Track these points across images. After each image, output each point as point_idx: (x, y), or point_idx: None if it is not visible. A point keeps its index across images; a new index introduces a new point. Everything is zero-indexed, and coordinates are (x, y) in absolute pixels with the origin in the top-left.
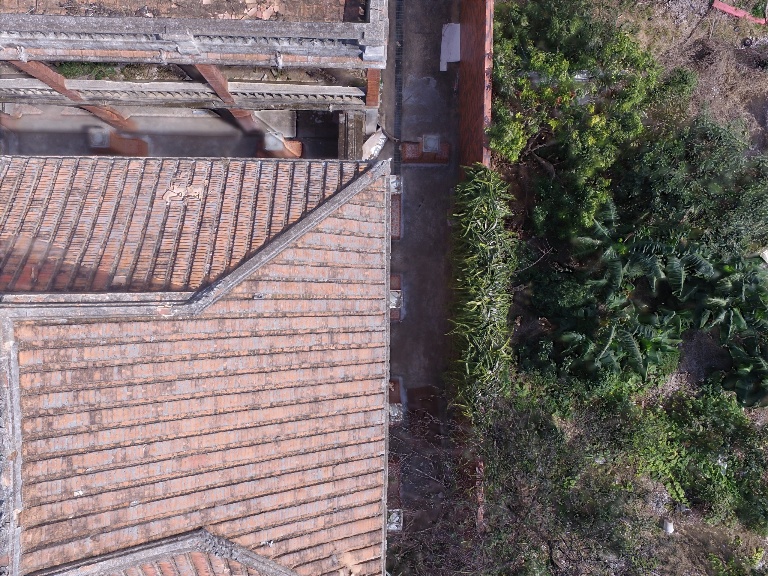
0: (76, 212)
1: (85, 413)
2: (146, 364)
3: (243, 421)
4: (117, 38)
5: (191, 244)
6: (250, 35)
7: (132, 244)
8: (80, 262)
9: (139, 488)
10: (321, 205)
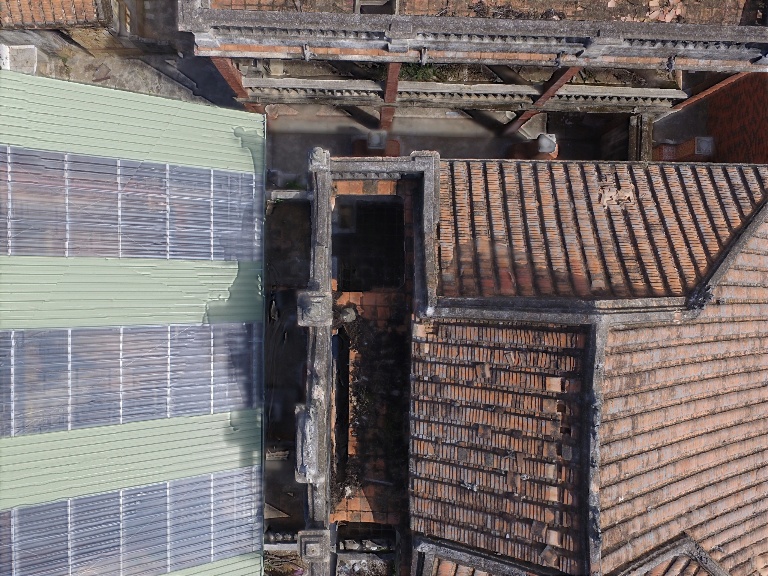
0: (519, 216)
1: (628, 418)
2: (661, 369)
3: (709, 426)
4: (528, 41)
5: (649, 248)
6: (679, 38)
7: (591, 248)
8: (548, 266)
9: (655, 493)
10: (760, 209)
